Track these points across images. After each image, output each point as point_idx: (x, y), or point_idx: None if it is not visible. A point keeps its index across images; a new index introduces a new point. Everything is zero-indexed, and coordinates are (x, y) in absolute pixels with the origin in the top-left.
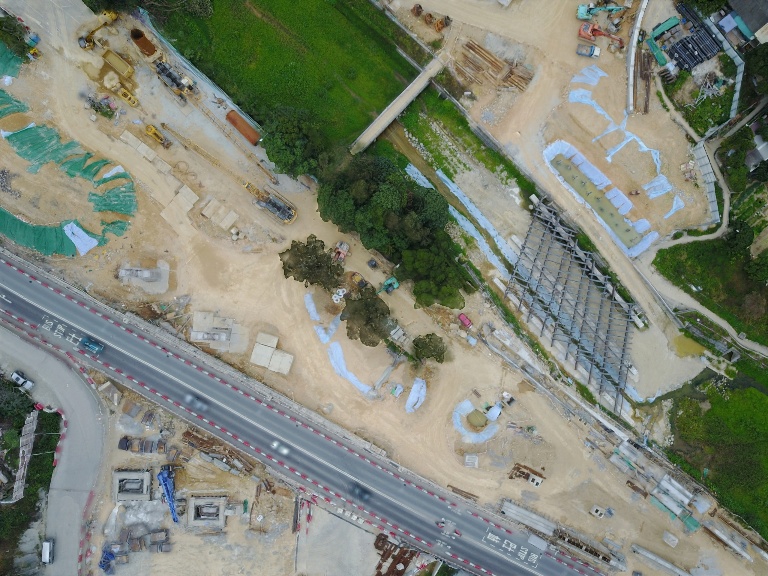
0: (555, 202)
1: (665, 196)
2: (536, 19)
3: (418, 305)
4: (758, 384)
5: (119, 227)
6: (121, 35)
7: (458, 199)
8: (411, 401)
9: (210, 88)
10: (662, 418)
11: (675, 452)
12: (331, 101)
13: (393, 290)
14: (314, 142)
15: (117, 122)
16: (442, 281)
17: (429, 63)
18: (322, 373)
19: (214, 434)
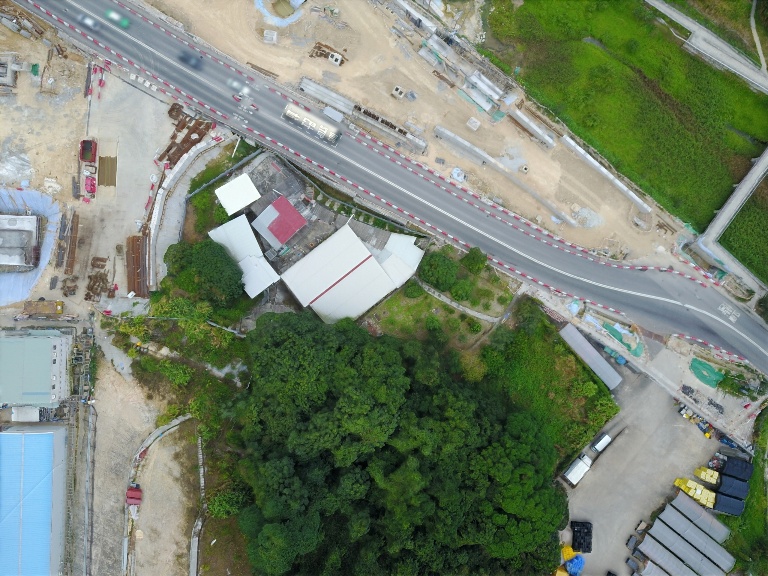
0: None
1: None
2: None
3: None
4: None
5: None
6: None
7: None
8: None
9: None
10: (474, 14)
11: (486, 48)
12: None
13: None
14: None
15: None
16: None
17: None
18: None
19: None
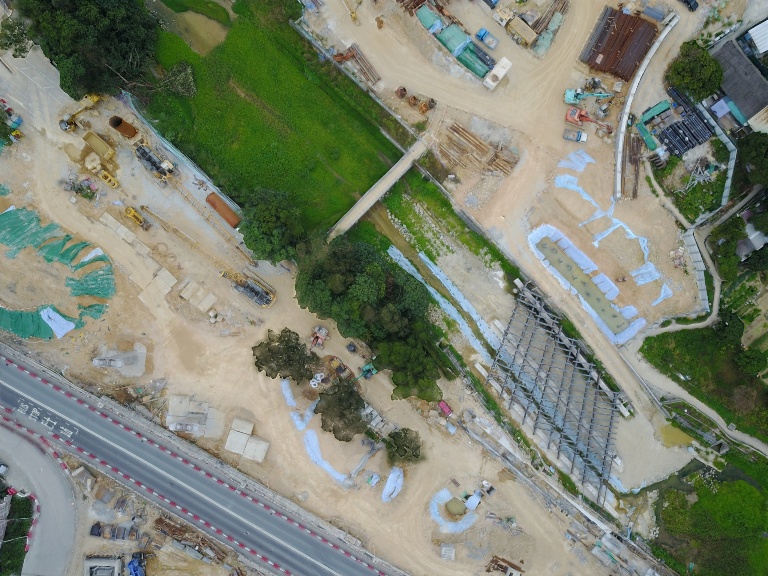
0: (539, 288)
1: (653, 284)
2: (522, 102)
3: (395, 396)
4: (748, 477)
5: (96, 310)
6: (103, 116)
7: (441, 282)
8: (387, 491)
9: (191, 169)
10: (647, 510)
11: (660, 545)
12: (313, 182)
13: (372, 375)
14: (292, 230)
15: (97, 203)
16: (420, 372)
17: (413, 145)
18: (298, 460)
19: (187, 521)
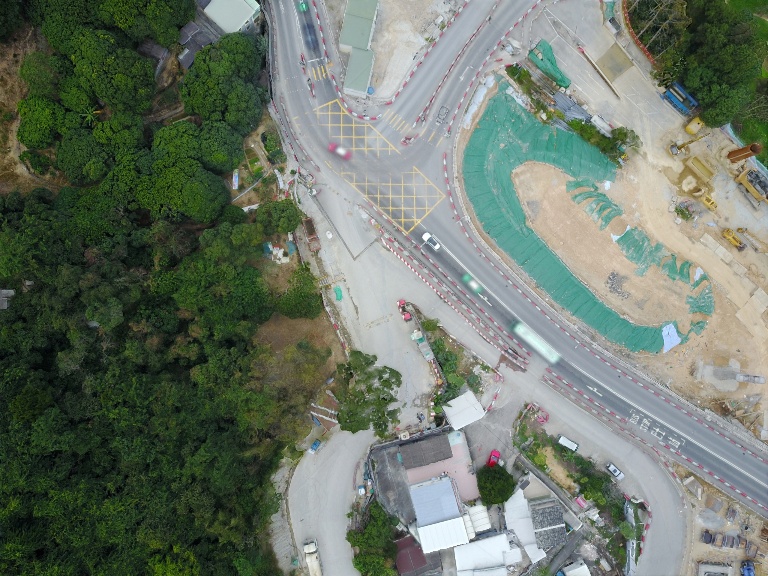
0: None
1: None
2: None
3: None
4: None
5: (700, 327)
6: (701, 141)
7: None
8: None
9: None
10: None
11: None
12: None
13: None
14: None
15: (695, 225)
16: None
17: None
18: None
19: None
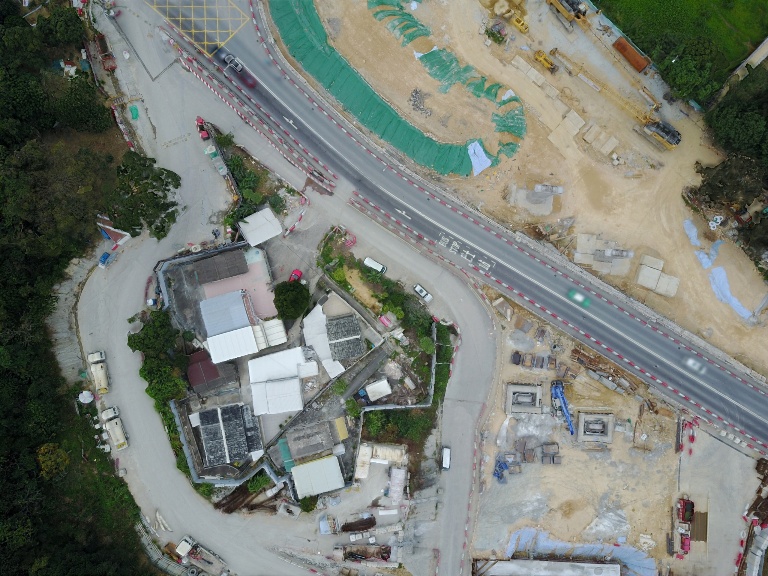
0: None
1: None
2: None
3: None
4: None
5: (511, 149)
6: None
7: None
8: None
9: (596, 15)
10: None
11: None
12: (708, 30)
13: None
14: (718, 65)
15: (507, 47)
16: None
17: None
18: (703, 298)
19: (600, 353)
